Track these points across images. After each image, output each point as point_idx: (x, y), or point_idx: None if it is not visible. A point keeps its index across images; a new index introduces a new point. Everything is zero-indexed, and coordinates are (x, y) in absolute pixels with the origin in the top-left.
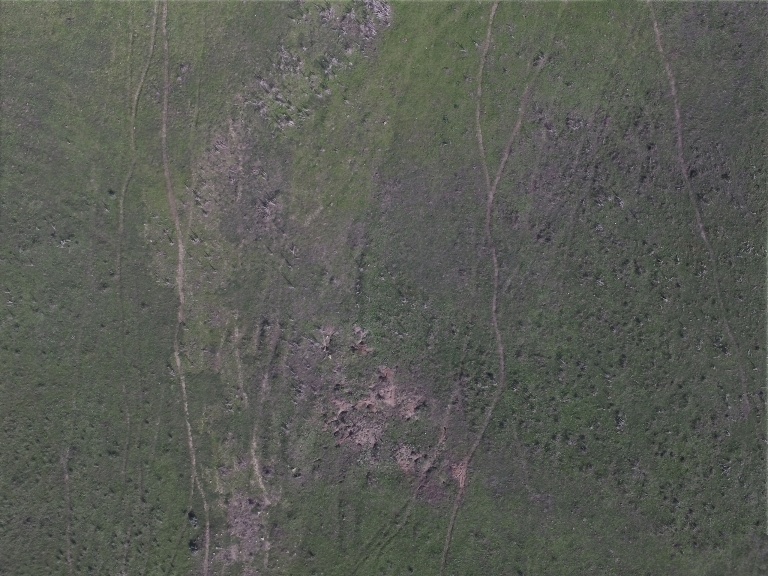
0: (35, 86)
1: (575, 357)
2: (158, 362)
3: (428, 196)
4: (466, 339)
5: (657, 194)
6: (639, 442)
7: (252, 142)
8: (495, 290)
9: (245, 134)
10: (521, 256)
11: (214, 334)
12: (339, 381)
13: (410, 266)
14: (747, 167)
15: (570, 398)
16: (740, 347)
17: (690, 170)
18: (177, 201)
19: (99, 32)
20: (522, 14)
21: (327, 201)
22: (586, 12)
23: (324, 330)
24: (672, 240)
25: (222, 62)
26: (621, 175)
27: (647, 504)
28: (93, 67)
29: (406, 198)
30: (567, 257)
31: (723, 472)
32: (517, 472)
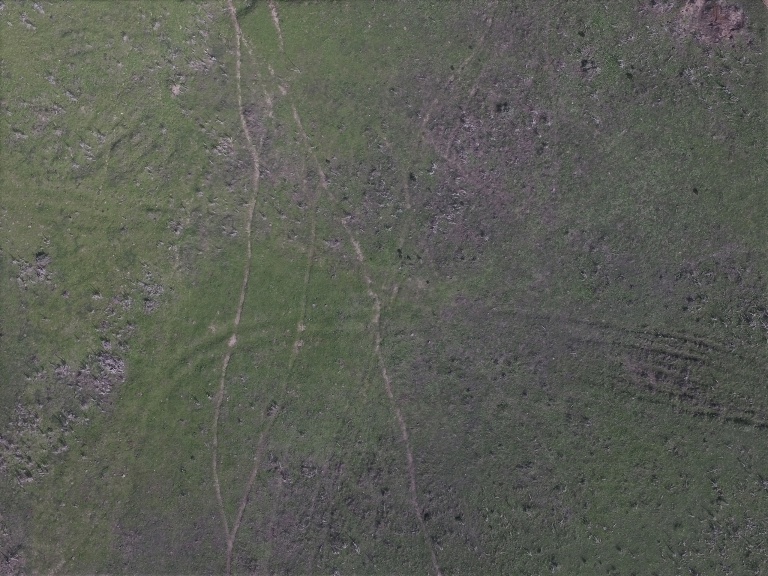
0: None
1: None
2: None
3: (168, 547)
4: None
5: (393, 538)
6: None
7: None
8: None
9: None
10: None
11: None
12: None
13: None
14: (480, 509)
15: None
16: None
17: (424, 514)
18: None
19: None
20: (254, 365)
21: (69, 555)
22: (316, 362)
23: None
24: None
25: None
26: (357, 520)
27: None
28: None
29: (147, 549)
30: None
31: None
32: None
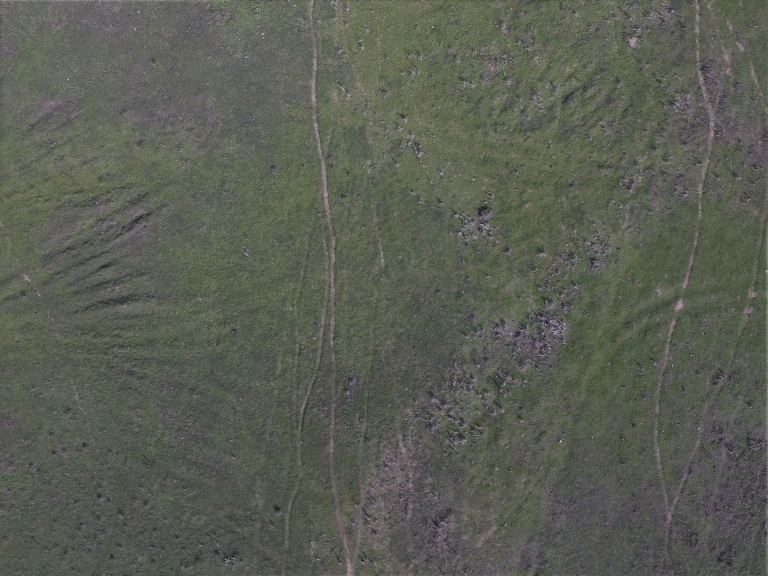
0: (199, 398)
1: None
2: None
3: (605, 517)
4: None
5: None
6: None
7: (423, 459)
8: None
9: (415, 450)
10: None
11: None
12: None
13: None
14: None
15: None
16: None
17: None
18: (345, 518)
19: (264, 343)
20: (701, 332)
21: (501, 521)
22: (767, 330)
23: None
24: None
25: (391, 376)
26: None
27: None
28: (258, 379)
29: (582, 518)
30: None
31: None
32: None
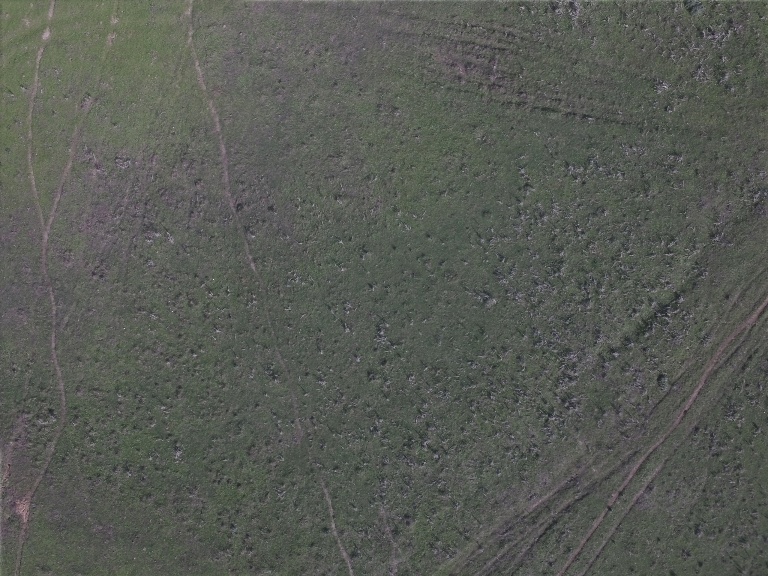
0: None
1: (133, 390)
2: None
3: None
4: (28, 376)
5: (206, 228)
6: (197, 470)
7: None
8: (54, 327)
9: None
10: (77, 293)
11: None
12: None
13: None
14: (292, 199)
15: (130, 430)
16: (291, 374)
17: (237, 203)
18: None
19: None
20: (68, 57)
21: None
22: (129, 54)
23: None
24: (222, 272)
25: None
26: (171, 211)
27: (206, 531)
28: None
29: None
30: (121, 293)
31: (278, 496)
32: (79, 505)
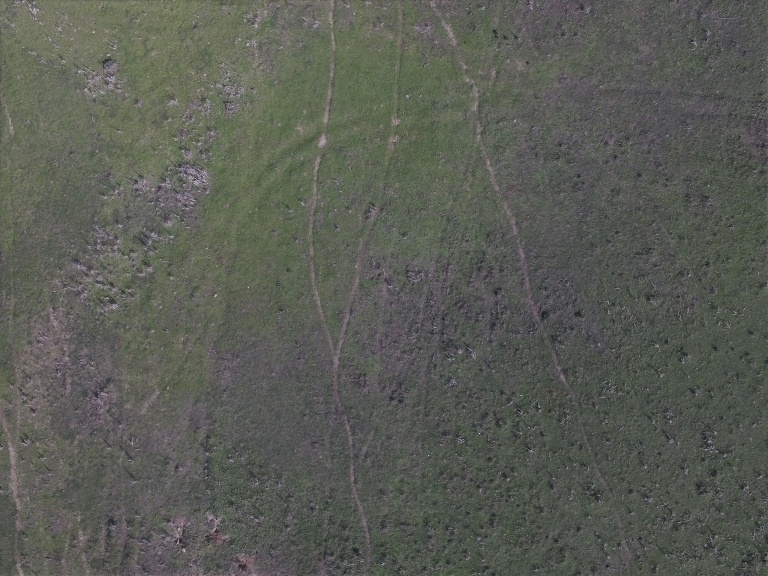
0: None
1: (443, 521)
2: (0, 575)
3: (270, 368)
4: (327, 515)
5: (510, 340)
6: None
7: (76, 330)
8: (351, 460)
9: (68, 322)
10: (375, 421)
11: (56, 540)
12: (196, 575)
13: (259, 444)
14: (600, 302)
15: (442, 565)
16: (613, 492)
17: (541, 312)
18: (2, 401)
19: None
20: (347, 166)
21: (163, 385)
22: (414, 157)
23: (174, 522)
24: (531, 387)
25: (35, 248)
26: (470, 324)
27: None
28: None
29: (247, 372)
30: (423, 417)
31: None
32: None
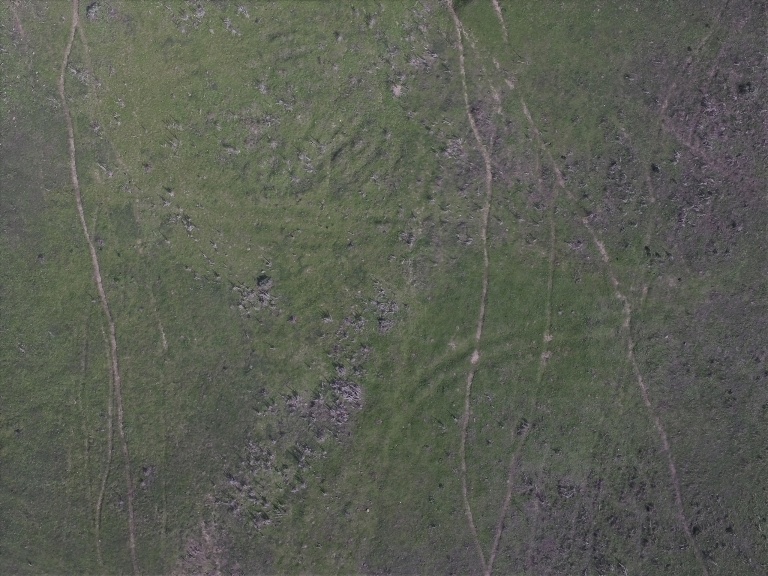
0: None
1: None
2: None
3: None
4: None
5: (661, 556)
6: None
7: (228, 544)
8: None
9: (220, 536)
10: None
11: None
12: None
13: None
14: (751, 517)
15: None
16: None
17: (693, 527)
18: None
19: (51, 441)
20: (500, 382)
21: None
22: (567, 373)
23: None
24: None
25: (187, 461)
26: (621, 540)
27: None
28: (48, 480)
29: None
30: None
31: None
32: None
